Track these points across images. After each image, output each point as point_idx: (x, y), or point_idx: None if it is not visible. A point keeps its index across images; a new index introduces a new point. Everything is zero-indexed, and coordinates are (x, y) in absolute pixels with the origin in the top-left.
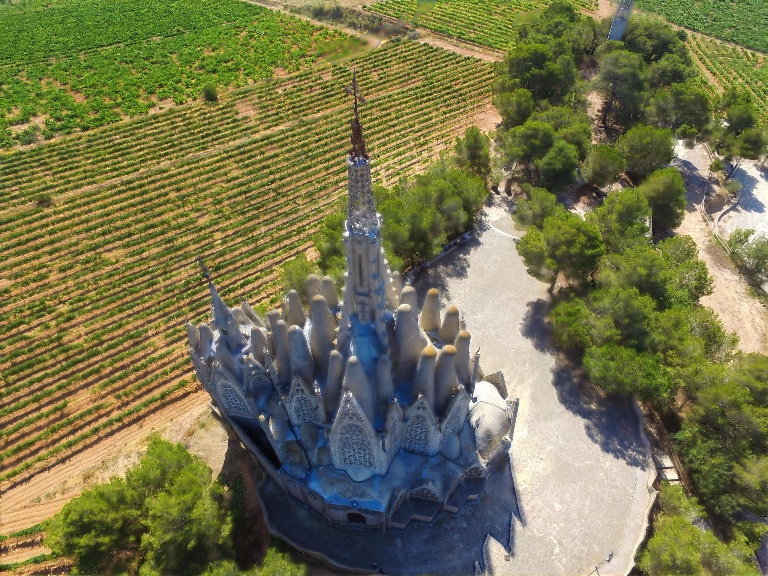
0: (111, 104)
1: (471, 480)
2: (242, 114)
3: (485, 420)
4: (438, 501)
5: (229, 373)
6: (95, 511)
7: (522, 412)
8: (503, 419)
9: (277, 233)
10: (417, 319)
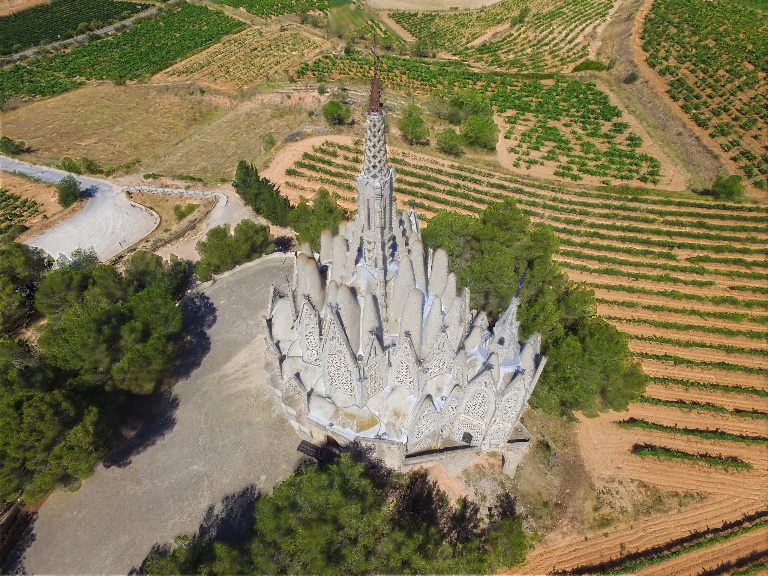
0: None
1: None
2: None
3: None
4: None
5: None
6: (598, 328)
7: (248, 351)
8: None
9: None
10: None
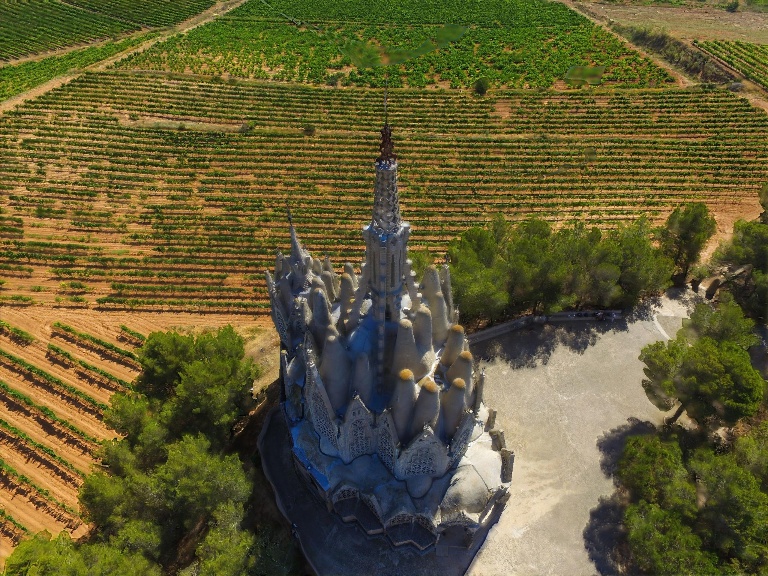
0: (403, 72)
1: (422, 528)
2: (497, 113)
3: (462, 484)
4: (380, 521)
5: (281, 304)
6: (164, 347)
7: (532, 513)
8: (482, 496)
9: (448, 227)
10: (428, 344)
